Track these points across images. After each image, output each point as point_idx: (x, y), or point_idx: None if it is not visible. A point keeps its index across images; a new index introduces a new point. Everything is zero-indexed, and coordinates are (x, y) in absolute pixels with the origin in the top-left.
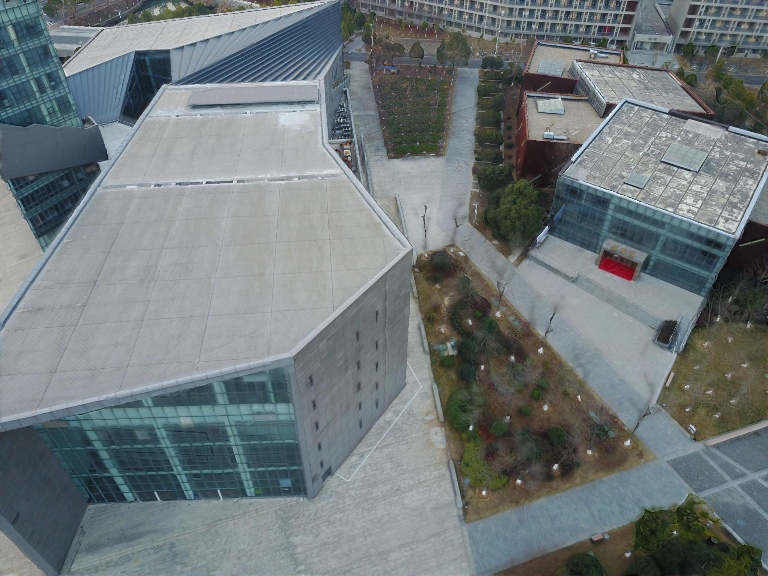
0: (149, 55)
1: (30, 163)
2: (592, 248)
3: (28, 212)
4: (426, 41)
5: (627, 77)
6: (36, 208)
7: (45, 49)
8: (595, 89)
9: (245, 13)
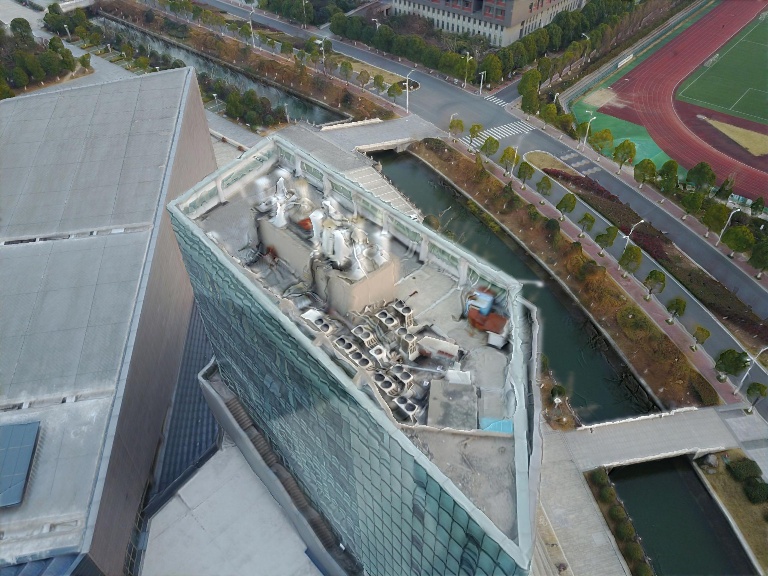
0: None
1: None
2: None
3: None
4: None
5: None
6: None
7: None
8: None
9: None
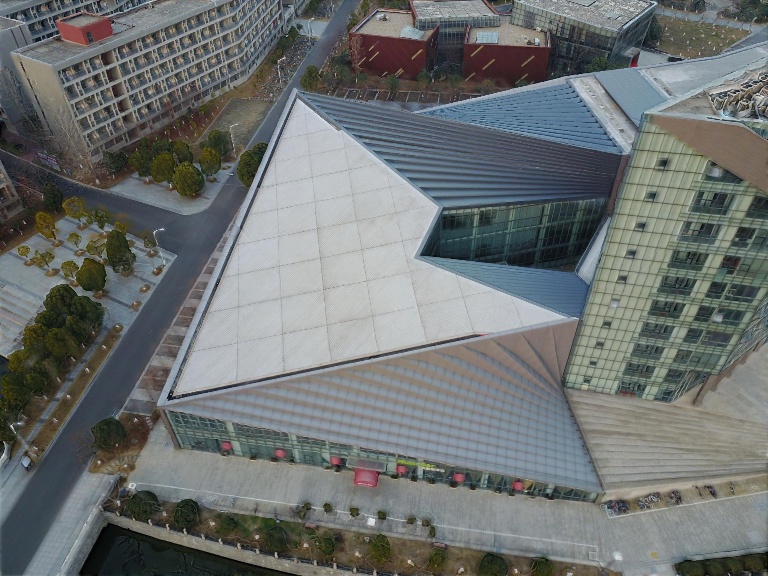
0: (426, 244)
1: None
2: None
3: None
4: (217, 123)
5: None
6: None
7: None
8: (473, 16)
9: (273, 174)
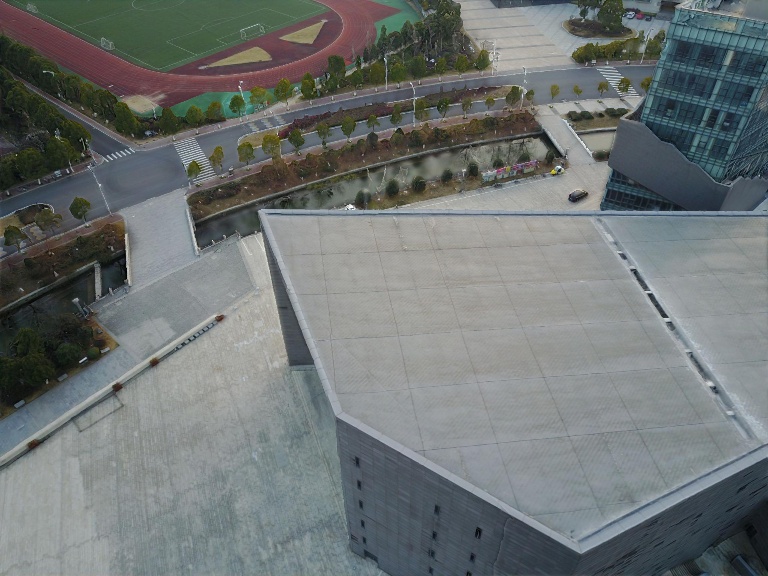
0: None
1: (639, 170)
2: None
3: (606, 203)
4: None
5: None
6: (615, 206)
7: (748, 90)
8: None
9: None
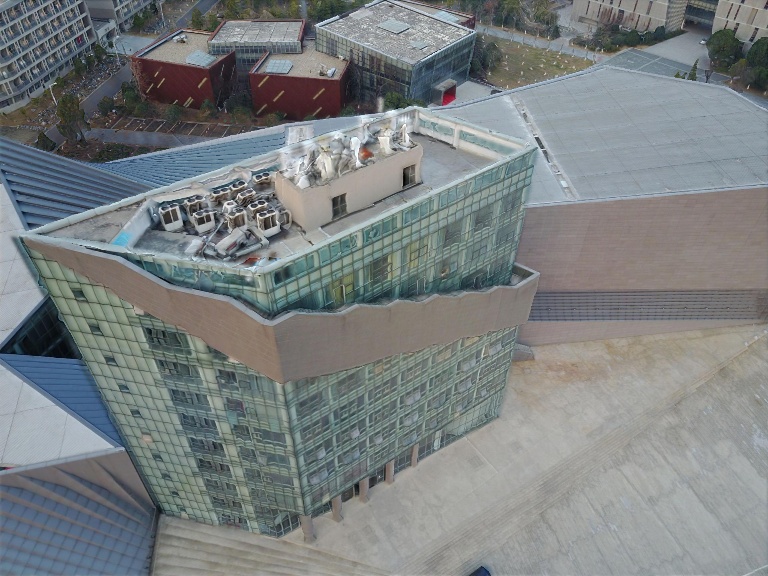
0: (20, 336)
1: None
2: (427, 103)
3: None
4: None
5: (241, 32)
6: None
7: None
8: (271, 42)
9: None
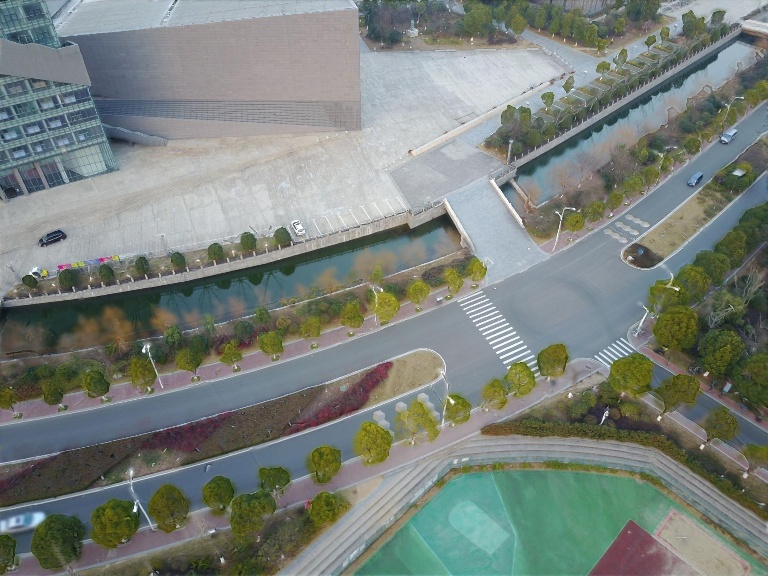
0: None
1: None
2: None
3: None
4: None
5: None
6: None
7: None
8: None
9: None
